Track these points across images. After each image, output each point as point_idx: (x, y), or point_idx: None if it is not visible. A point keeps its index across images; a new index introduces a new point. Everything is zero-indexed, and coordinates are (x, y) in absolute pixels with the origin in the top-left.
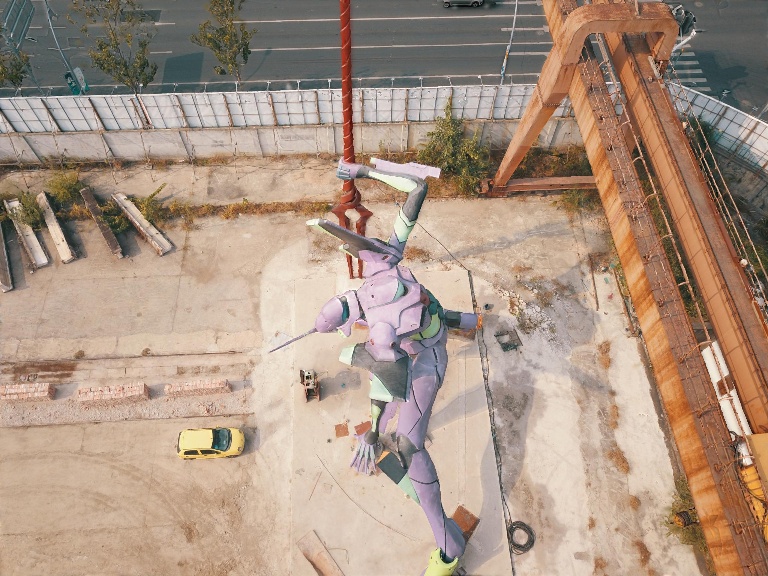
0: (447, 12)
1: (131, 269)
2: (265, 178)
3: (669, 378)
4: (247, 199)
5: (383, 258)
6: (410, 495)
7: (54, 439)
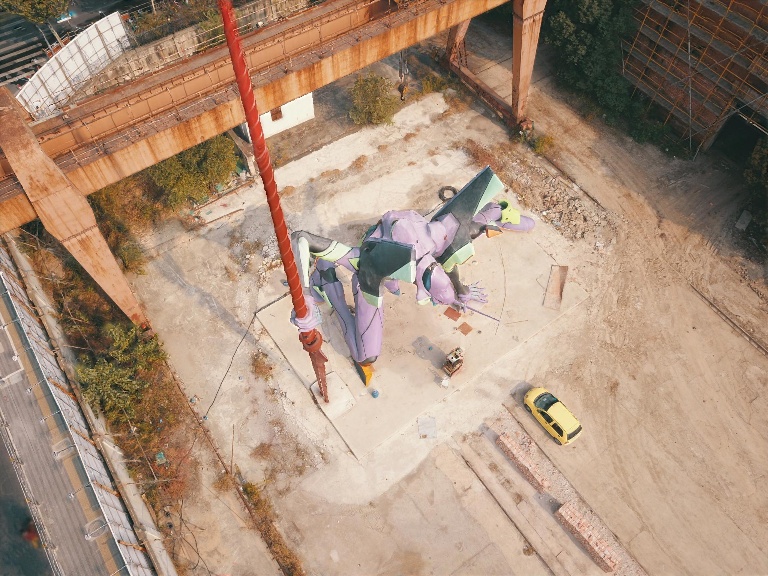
0: None
1: None
2: None
3: None
4: None
5: None
6: None
7: (659, 565)
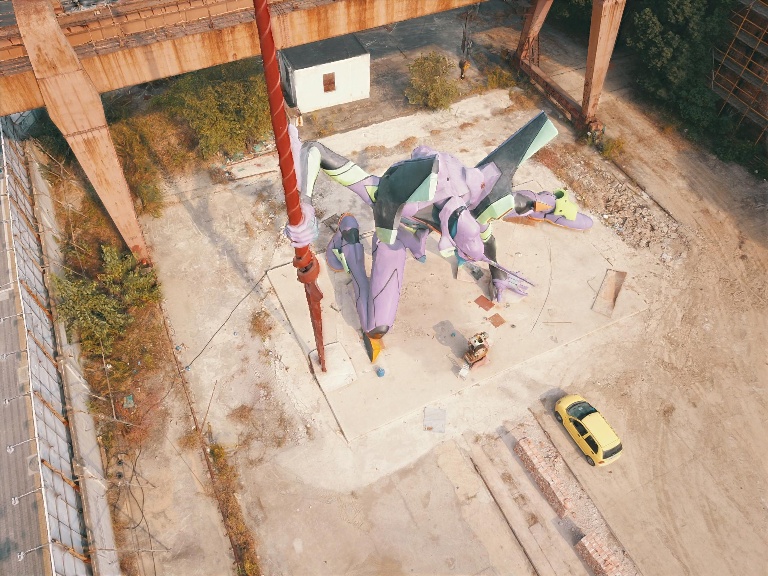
0: None
1: None
2: (177, 574)
3: None
4: None
5: None
6: None
7: None
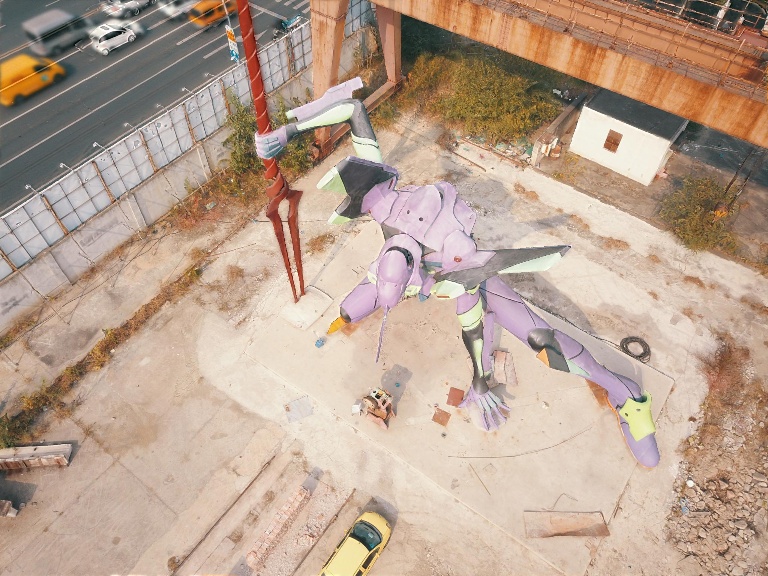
0: (112, 59)
1: (45, 512)
2: (98, 300)
3: (669, 89)
4: (102, 333)
5: (388, 187)
6: (581, 374)
7: None
